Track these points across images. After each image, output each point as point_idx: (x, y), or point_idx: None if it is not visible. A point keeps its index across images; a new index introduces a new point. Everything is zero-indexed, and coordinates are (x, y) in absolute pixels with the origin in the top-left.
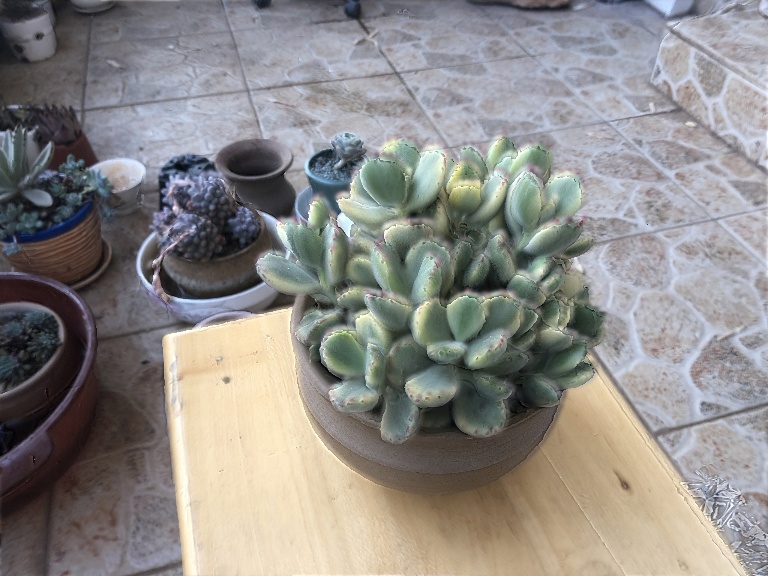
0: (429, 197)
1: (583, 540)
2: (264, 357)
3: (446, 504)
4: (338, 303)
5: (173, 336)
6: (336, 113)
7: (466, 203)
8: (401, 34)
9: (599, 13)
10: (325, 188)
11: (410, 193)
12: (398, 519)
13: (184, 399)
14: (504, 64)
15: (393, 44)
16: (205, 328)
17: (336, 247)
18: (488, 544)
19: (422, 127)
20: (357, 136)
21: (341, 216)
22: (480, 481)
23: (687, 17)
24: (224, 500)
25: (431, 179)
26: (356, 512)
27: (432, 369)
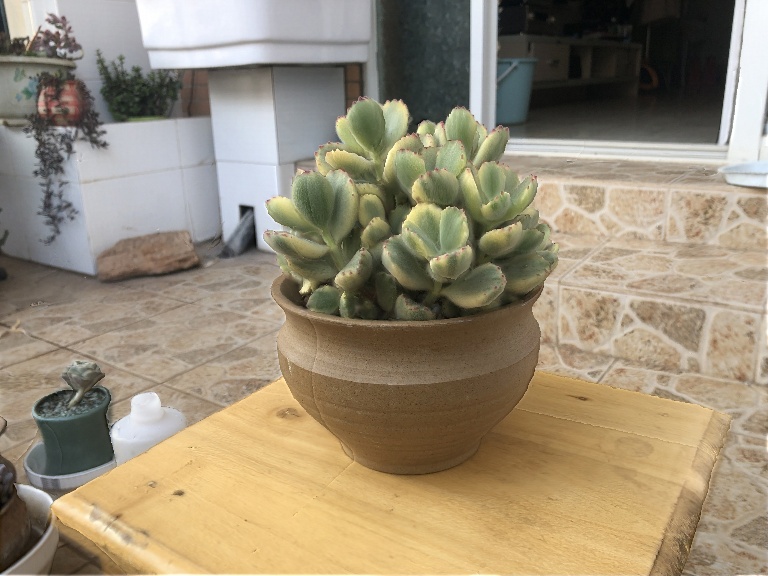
0: (401, 130)
1: (597, 434)
2: (204, 461)
3: (485, 466)
4: (366, 234)
5: (67, 495)
6: (11, 396)
7: None
8: (47, 319)
9: (228, 264)
10: (68, 427)
11: (384, 134)
12: (461, 492)
13: (142, 527)
14: (169, 314)
15: (43, 328)
16: None
17: None
18: (544, 468)
19: (120, 378)
20: None
21: (113, 432)
22: (527, 378)
23: None
24: (284, 568)
25: (399, 115)
26: (422, 507)
27: None
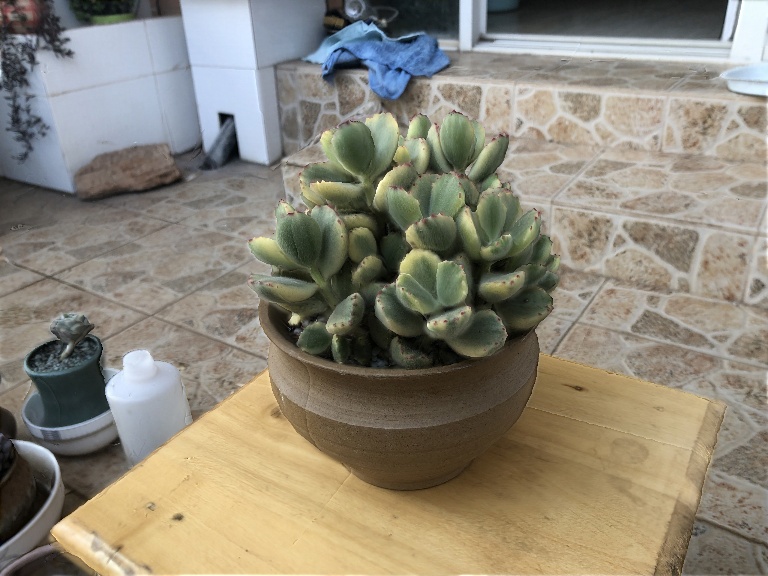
0: (392, 150)
1: (593, 434)
2: (201, 476)
3: (482, 476)
4: (357, 276)
5: (67, 520)
6: (2, 333)
7: (405, 161)
8: (29, 245)
9: (211, 177)
10: (62, 381)
11: None
12: (459, 511)
13: (144, 561)
14: (154, 236)
15: (26, 255)
16: (102, 492)
17: (339, 217)
18: (540, 479)
19: (110, 310)
20: (42, 343)
21: (107, 390)
22: (525, 401)
23: (284, 159)
24: None
25: (389, 132)
26: (420, 530)
27: (484, 276)
